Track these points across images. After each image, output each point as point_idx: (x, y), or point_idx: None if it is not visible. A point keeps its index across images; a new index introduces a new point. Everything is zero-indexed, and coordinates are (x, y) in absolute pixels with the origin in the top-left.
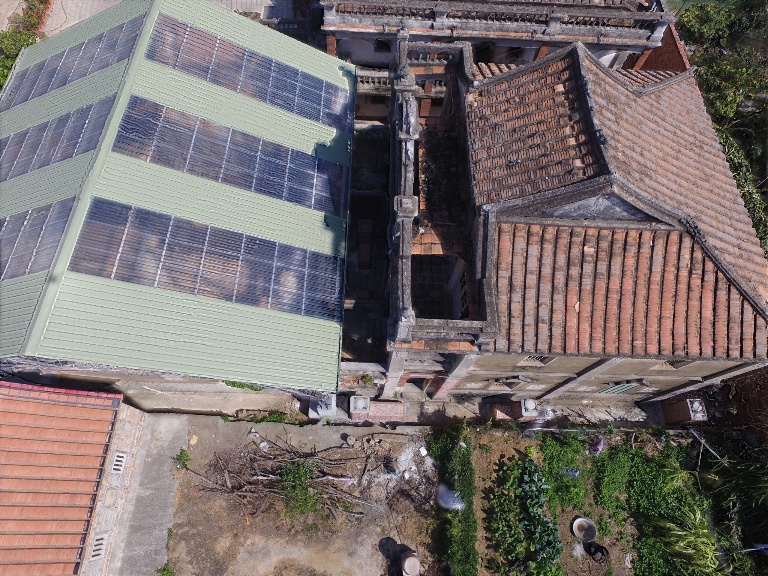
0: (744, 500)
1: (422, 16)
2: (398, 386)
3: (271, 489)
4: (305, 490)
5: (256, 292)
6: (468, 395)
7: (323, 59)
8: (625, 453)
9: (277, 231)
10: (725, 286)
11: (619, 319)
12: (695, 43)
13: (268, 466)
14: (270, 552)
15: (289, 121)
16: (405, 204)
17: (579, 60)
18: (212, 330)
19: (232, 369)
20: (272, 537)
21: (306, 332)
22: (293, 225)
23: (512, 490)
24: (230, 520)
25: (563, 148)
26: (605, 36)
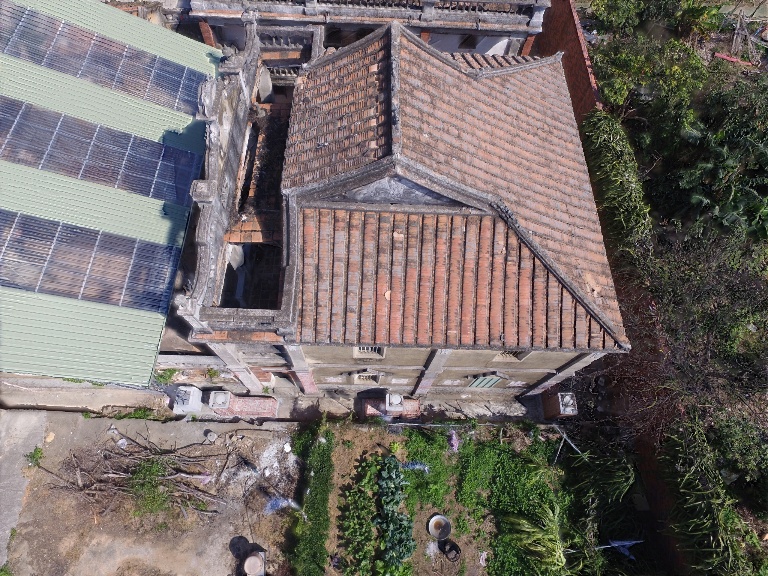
0: (602, 496)
1: (292, 1)
2: (263, 381)
3: (120, 487)
4: (154, 488)
5: (66, 282)
6: (341, 390)
7: (188, 45)
8: (492, 448)
9: (102, 219)
10: (543, 273)
11: (433, 308)
12: (608, 32)
13: (123, 463)
14: (115, 552)
15: (136, 107)
16: (200, 188)
17: (391, 39)
18: (4, 321)
19: (22, 361)
20: (119, 536)
21: (121, 323)
22: (123, 213)
23: (369, 487)
24: (78, 519)
25: (365, 130)
26: (484, 22)
